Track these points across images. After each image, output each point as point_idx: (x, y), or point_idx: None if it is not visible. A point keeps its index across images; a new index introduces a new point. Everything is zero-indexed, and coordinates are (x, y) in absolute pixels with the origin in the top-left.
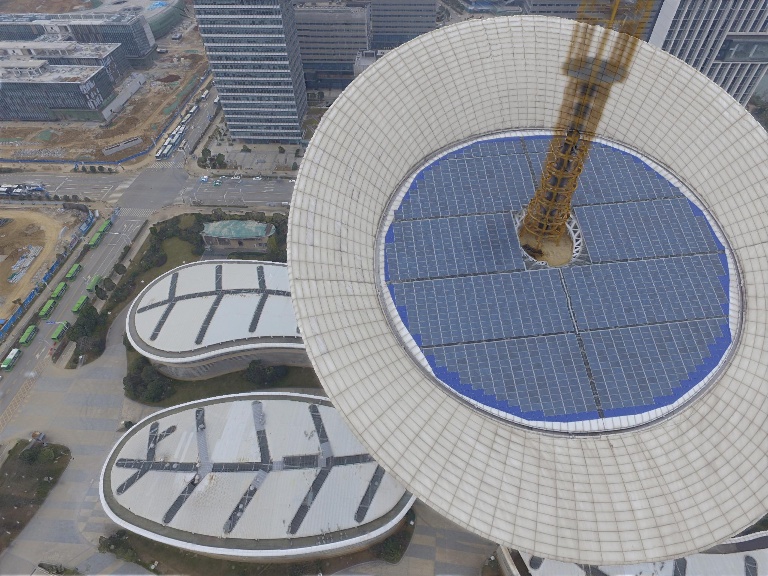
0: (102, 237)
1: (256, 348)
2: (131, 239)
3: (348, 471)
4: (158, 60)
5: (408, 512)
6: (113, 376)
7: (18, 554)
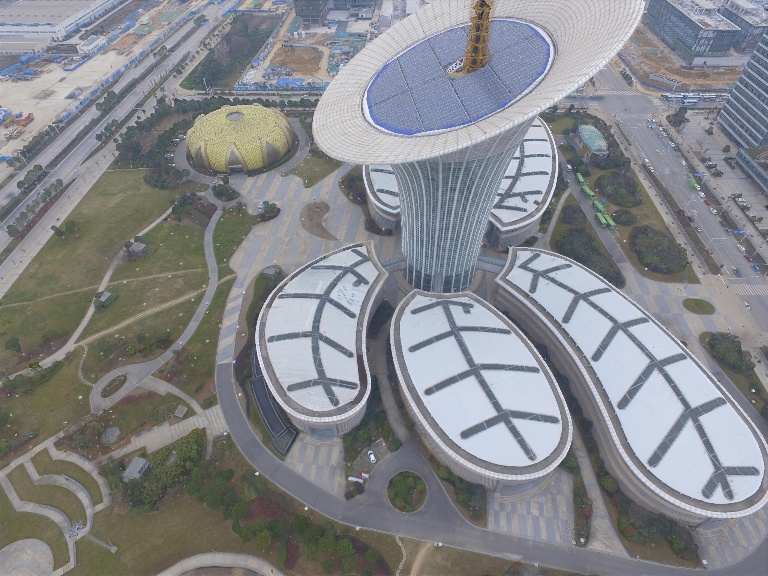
0: None
1: None
2: (566, 107)
3: None
4: None
5: (390, 229)
6: None
7: None
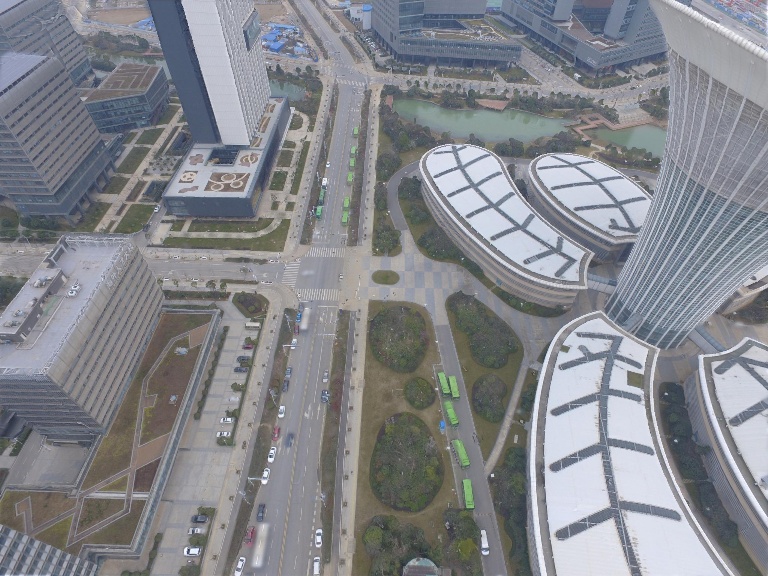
0: None
1: None
2: None
3: None
4: None
5: None
6: None
7: None
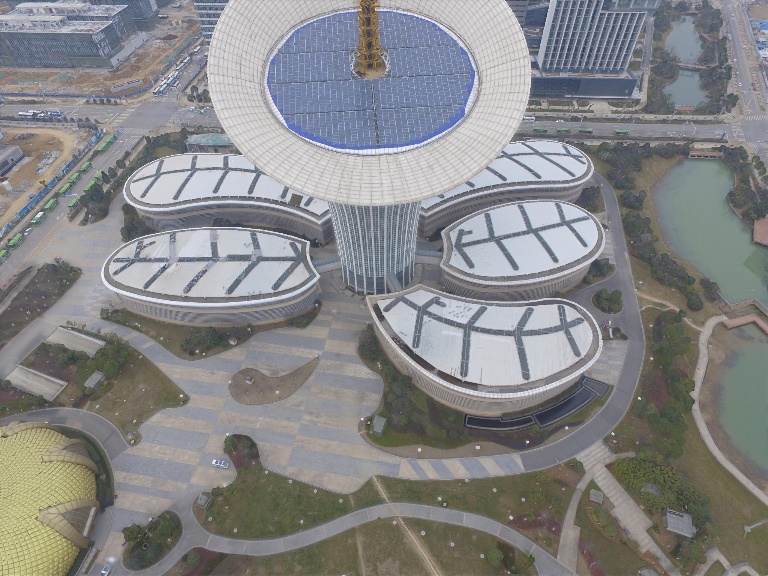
0: (108, 146)
1: (218, 206)
2: (131, 148)
3: (271, 264)
4: (160, 24)
5: (315, 300)
6: (113, 230)
7: (45, 321)
